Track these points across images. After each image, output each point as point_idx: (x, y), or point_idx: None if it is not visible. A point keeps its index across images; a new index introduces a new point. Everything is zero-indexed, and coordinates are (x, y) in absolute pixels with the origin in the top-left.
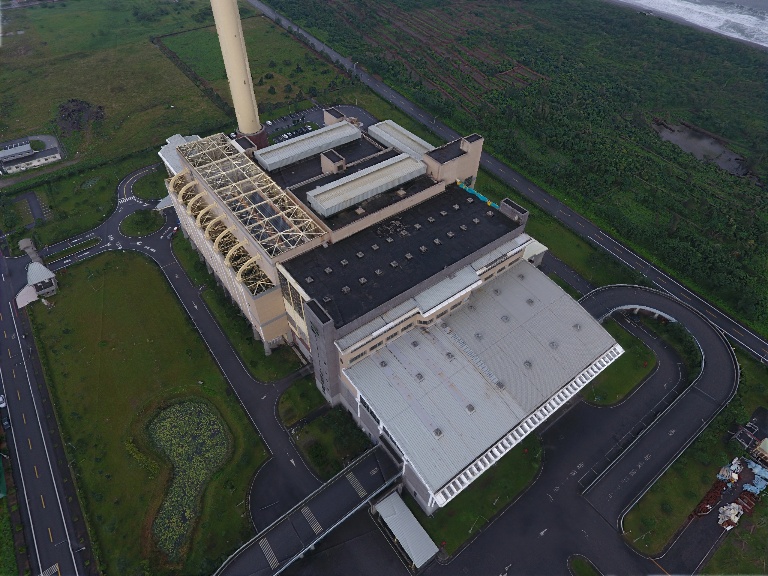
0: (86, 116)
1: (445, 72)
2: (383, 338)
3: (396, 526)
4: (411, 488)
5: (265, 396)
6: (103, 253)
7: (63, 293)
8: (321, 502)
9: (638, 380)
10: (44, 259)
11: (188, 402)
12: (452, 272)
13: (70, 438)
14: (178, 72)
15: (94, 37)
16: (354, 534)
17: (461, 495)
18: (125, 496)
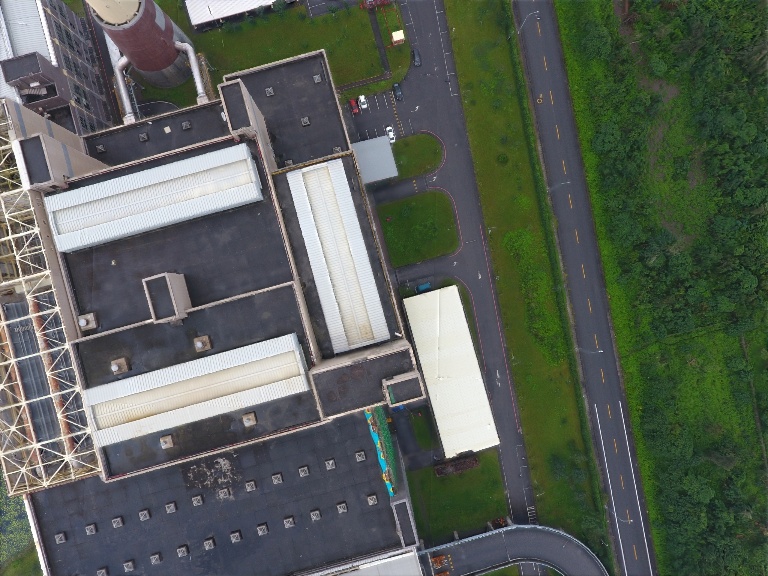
0: None
1: None
2: None
3: None
4: None
5: None
6: None
7: None
8: None
9: None
10: None
11: None
12: None
13: None
14: None
15: None
16: None
17: None
18: None
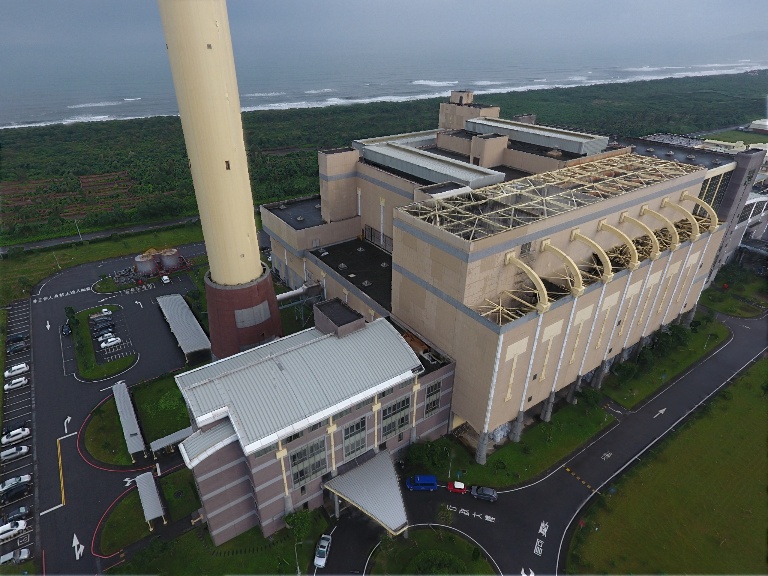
0: None
1: None
2: None
3: None
4: None
5: (745, 326)
6: None
7: None
8: None
9: None
10: None
11: None
12: None
13: None
14: None
15: None
16: None
17: None
18: None
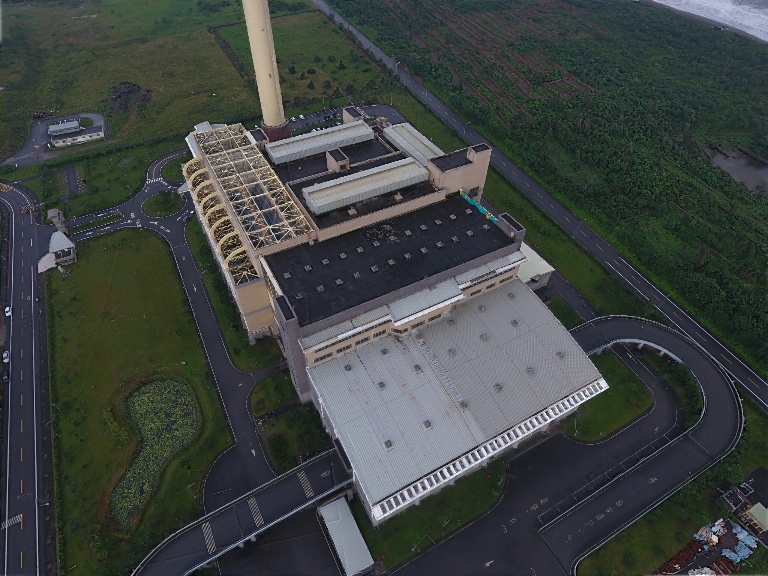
0: (134, 98)
1: (489, 78)
2: (352, 342)
3: (336, 532)
4: (361, 496)
5: (241, 384)
6: (122, 229)
7: (79, 263)
8: (268, 496)
9: (627, 419)
10: (70, 229)
11: (169, 380)
12: (433, 283)
13: (57, 399)
14: (227, 62)
15: (157, 24)
16: (297, 533)
17: (412, 511)
18: (93, 461)
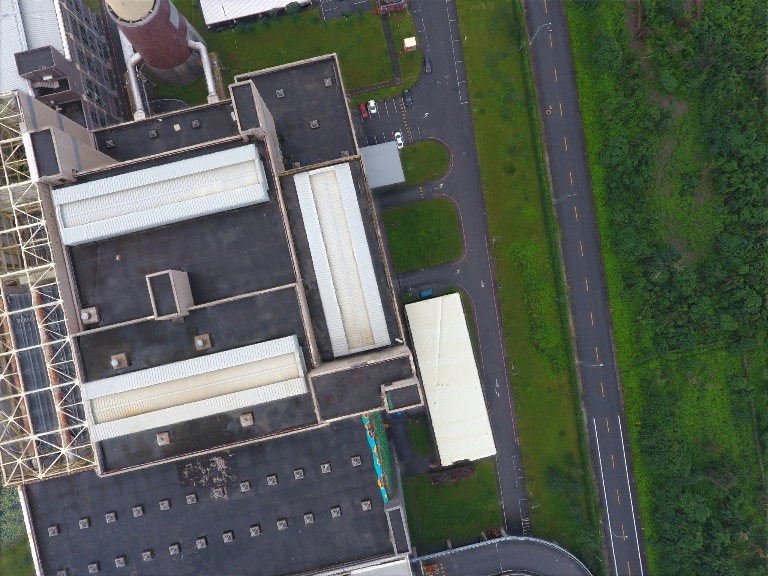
0: None
1: None
2: None
3: None
4: None
5: None
6: None
7: None
8: None
9: None
10: None
11: None
12: None
13: None
14: None
15: None
16: None
17: None
18: None
